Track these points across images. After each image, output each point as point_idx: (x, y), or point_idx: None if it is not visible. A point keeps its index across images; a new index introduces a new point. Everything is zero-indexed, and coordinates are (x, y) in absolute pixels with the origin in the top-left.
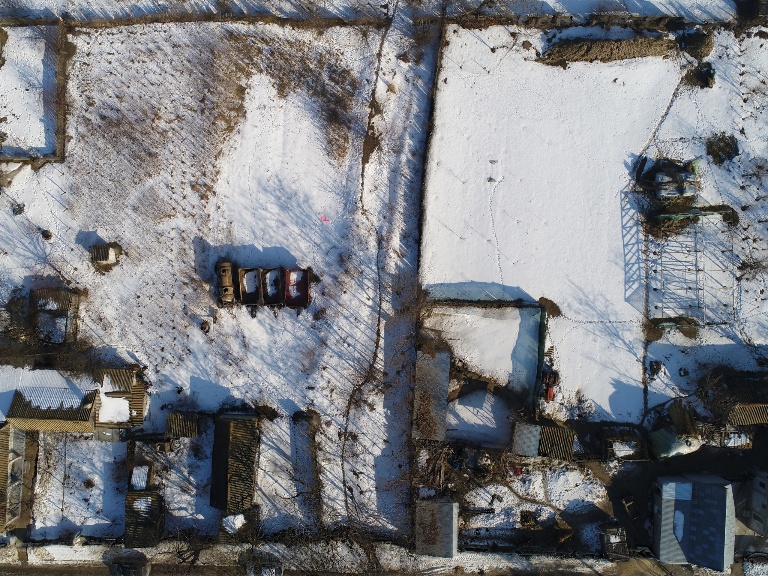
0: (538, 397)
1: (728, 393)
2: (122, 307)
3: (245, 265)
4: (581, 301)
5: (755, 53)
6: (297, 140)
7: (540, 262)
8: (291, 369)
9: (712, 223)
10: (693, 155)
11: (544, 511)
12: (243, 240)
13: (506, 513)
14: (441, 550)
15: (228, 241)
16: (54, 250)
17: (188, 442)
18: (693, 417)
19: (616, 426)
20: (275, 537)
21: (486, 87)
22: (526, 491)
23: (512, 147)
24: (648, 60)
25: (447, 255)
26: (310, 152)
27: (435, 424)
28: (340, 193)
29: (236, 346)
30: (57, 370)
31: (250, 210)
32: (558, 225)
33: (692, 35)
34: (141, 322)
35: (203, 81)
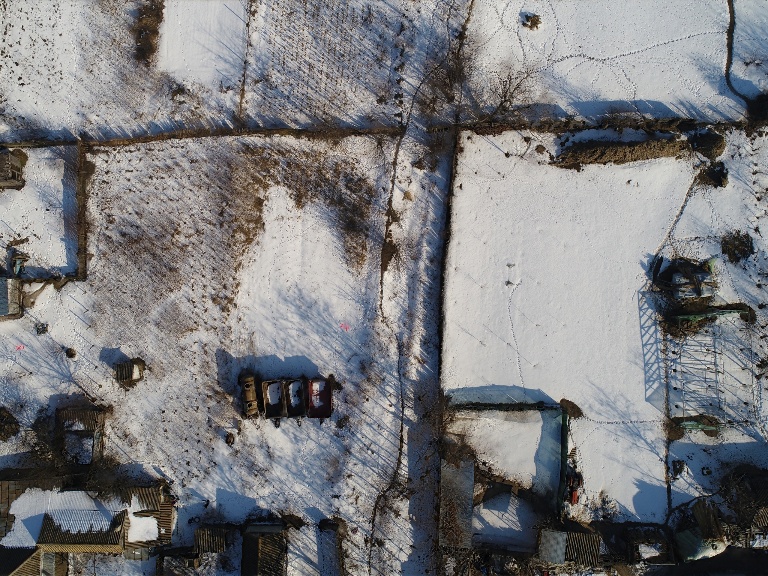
0: (562, 500)
1: (752, 498)
2: (147, 422)
3: (267, 375)
4: (602, 402)
5: (767, 152)
6: (315, 249)
7: (560, 364)
8: (316, 477)
9: (730, 322)
10: (709, 254)
11: None
12: (265, 350)
13: None
14: None
15: (250, 352)
16: (78, 368)
17: (216, 555)
18: (718, 518)
19: (641, 526)
20: None
21: (501, 191)
22: None
23: (529, 250)
24: (661, 161)
25: (467, 359)
26: (329, 261)
27: (461, 532)
28: (360, 301)
29: (261, 456)
30: (85, 491)
31: (271, 320)
32: (577, 327)
33: (704, 136)
34: (166, 437)
35: (221, 195)
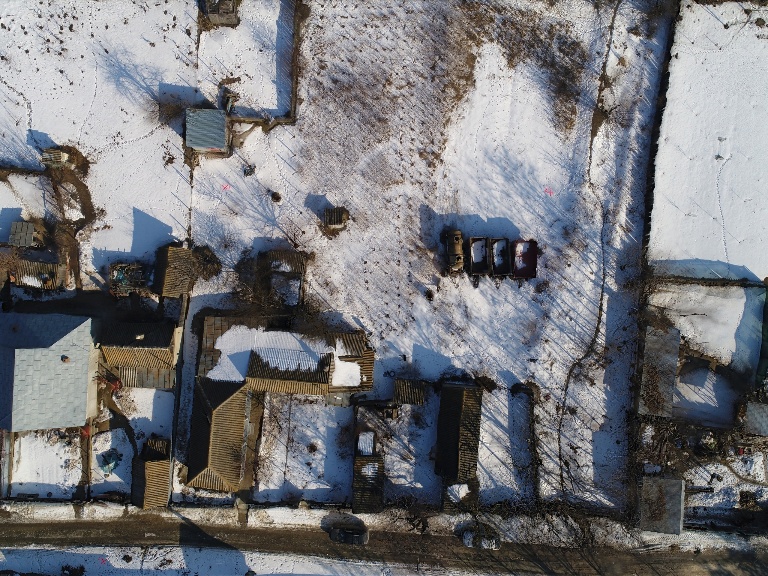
0: (762, 377)
1: None
2: (348, 272)
3: (469, 235)
4: None
5: None
6: (524, 111)
7: (766, 242)
8: (512, 341)
9: None
10: None
11: (765, 492)
12: (468, 209)
13: (726, 493)
14: (668, 527)
15: (453, 210)
16: (283, 213)
17: (409, 410)
18: None
19: None
20: (492, 508)
21: (717, 64)
22: (747, 471)
23: (741, 125)
24: None
25: (672, 232)
26: (537, 123)
27: (663, 400)
28: (566, 166)
29: (458, 316)
30: (290, 332)
31: (475, 180)
32: None
33: None
34: (367, 288)
35: (434, 48)
